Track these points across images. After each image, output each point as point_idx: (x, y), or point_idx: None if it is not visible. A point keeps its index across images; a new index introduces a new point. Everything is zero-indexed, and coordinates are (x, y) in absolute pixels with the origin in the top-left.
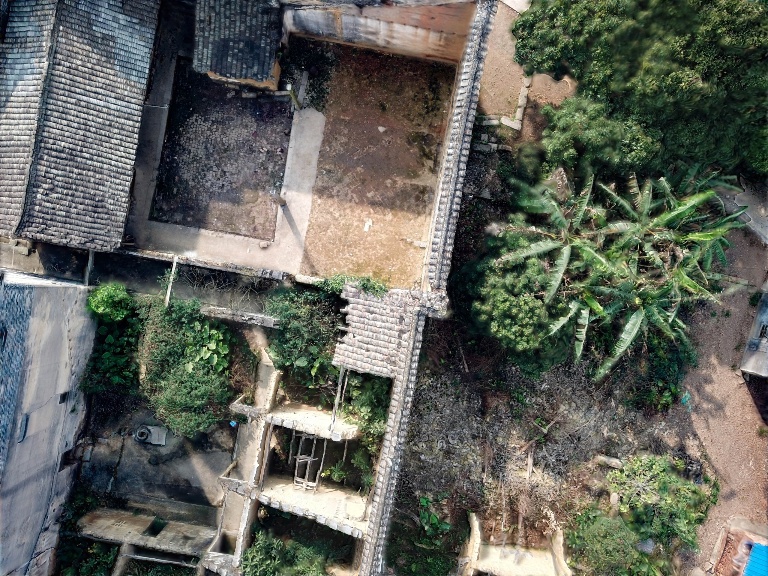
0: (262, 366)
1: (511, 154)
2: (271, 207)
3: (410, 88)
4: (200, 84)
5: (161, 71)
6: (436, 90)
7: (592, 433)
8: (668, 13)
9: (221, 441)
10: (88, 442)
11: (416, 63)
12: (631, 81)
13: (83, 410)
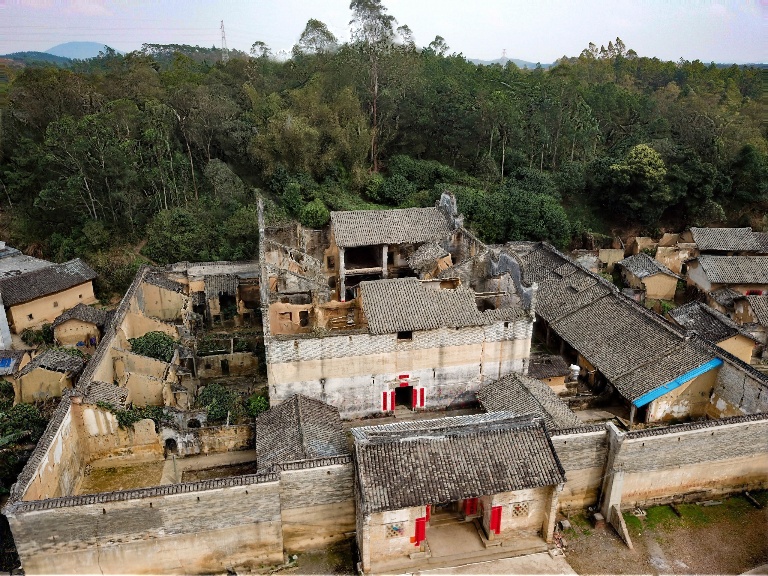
0: None
1: (6, 548)
2: None
3: None
4: None
5: None
6: None
7: None
8: None
9: None
10: None
11: None
12: None
13: None
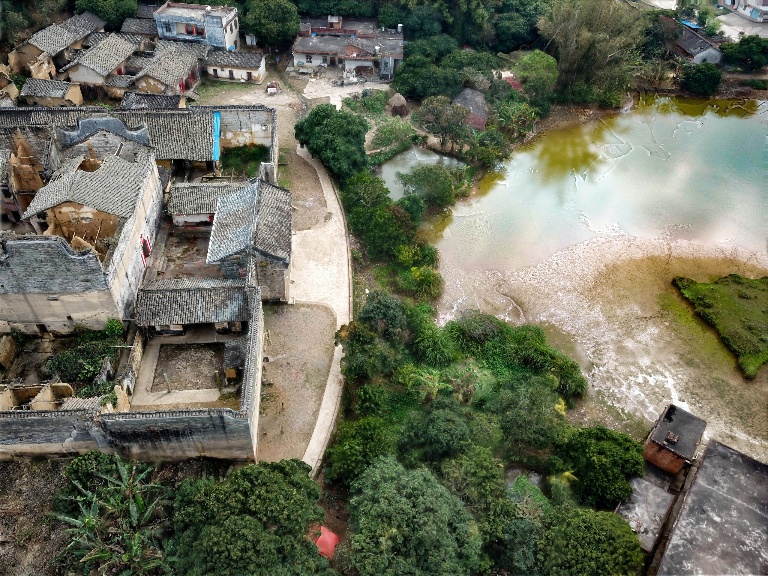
0: None
1: None
2: None
3: None
4: None
5: (233, 337)
6: None
7: None
8: None
9: None
10: (51, 339)
11: None
12: None
13: (66, 333)
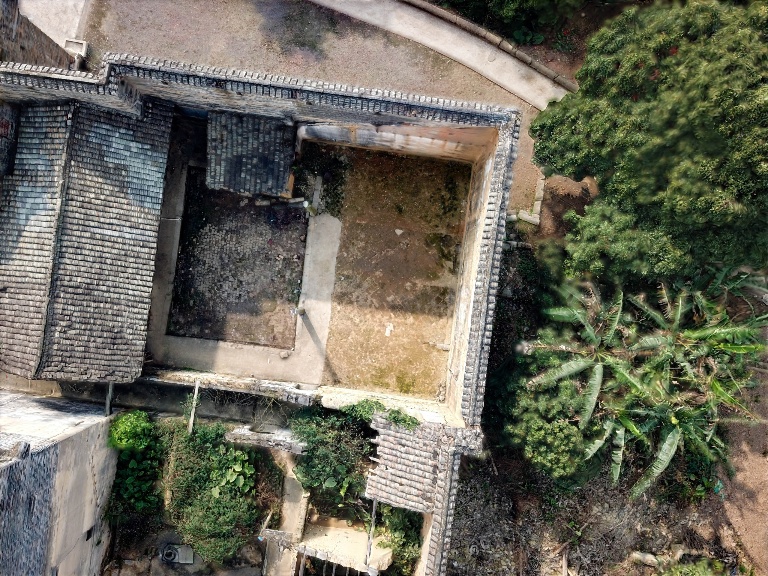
0: (288, 479)
1: (531, 252)
2: (290, 315)
3: (426, 189)
4: (212, 193)
5: (172, 183)
6: (452, 190)
7: (626, 531)
8: (694, 136)
9: (250, 556)
10: (115, 565)
11: (431, 163)
12: (656, 196)
13: (109, 535)
